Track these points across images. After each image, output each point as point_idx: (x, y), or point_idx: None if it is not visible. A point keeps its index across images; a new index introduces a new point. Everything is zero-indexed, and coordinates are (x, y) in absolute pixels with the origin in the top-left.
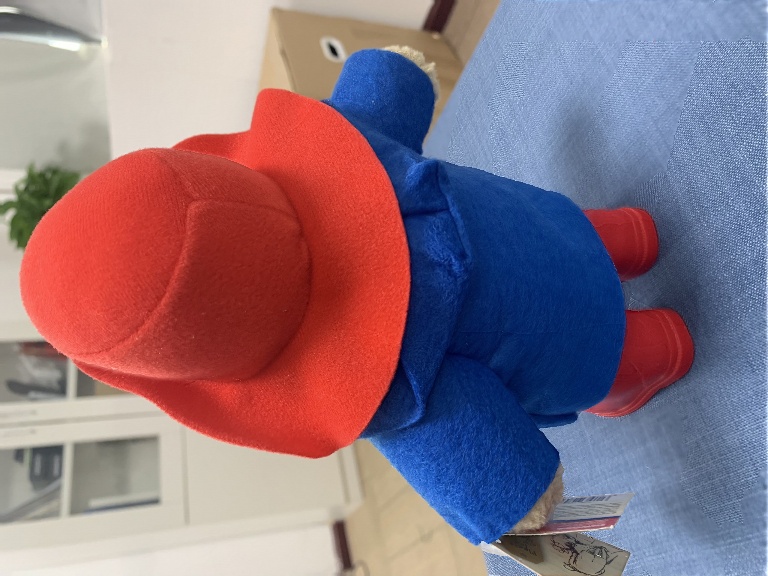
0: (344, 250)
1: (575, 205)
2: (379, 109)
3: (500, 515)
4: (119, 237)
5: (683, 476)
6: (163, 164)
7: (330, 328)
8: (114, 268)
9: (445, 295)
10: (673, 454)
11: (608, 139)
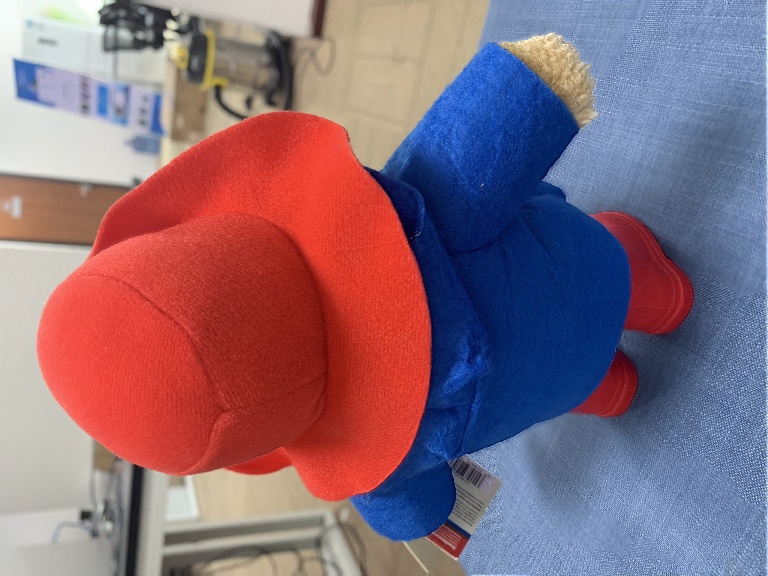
0: (355, 425)
1: (629, 287)
2: (483, 199)
3: (390, 536)
4: (143, 440)
5: (552, 445)
6: (198, 366)
7: (319, 450)
8: (136, 455)
9: (424, 465)
10: (557, 431)
11: (735, 197)
